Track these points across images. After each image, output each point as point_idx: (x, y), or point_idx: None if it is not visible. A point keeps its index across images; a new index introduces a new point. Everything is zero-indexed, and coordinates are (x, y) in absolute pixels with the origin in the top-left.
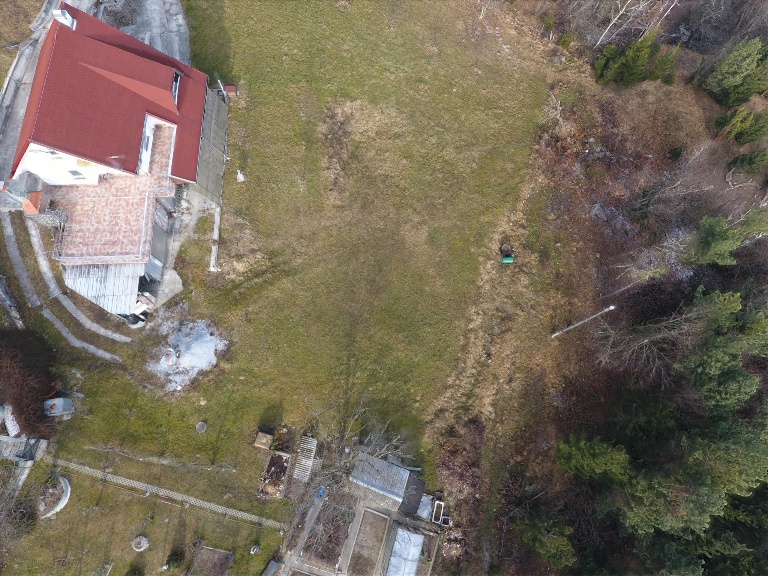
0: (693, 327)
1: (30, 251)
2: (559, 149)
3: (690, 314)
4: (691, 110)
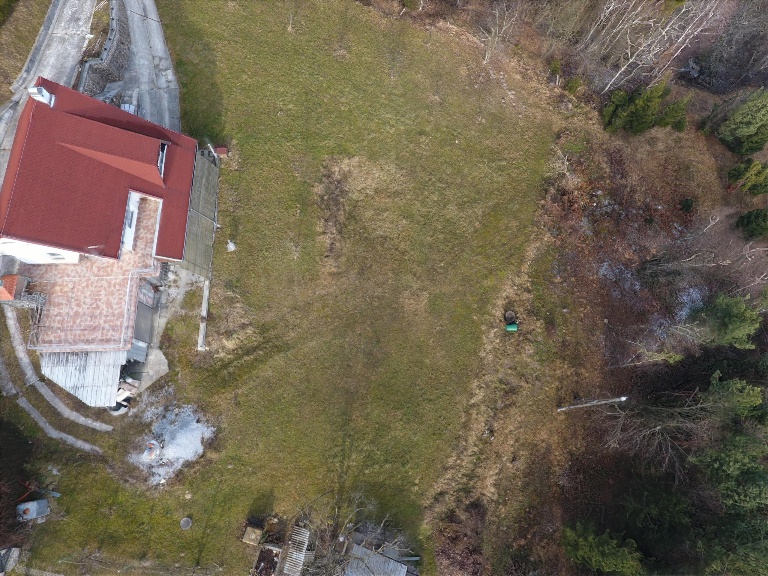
0: (709, 416)
1: (6, 335)
2: (566, 204)
3: (706, 404)
4: (702, 158)
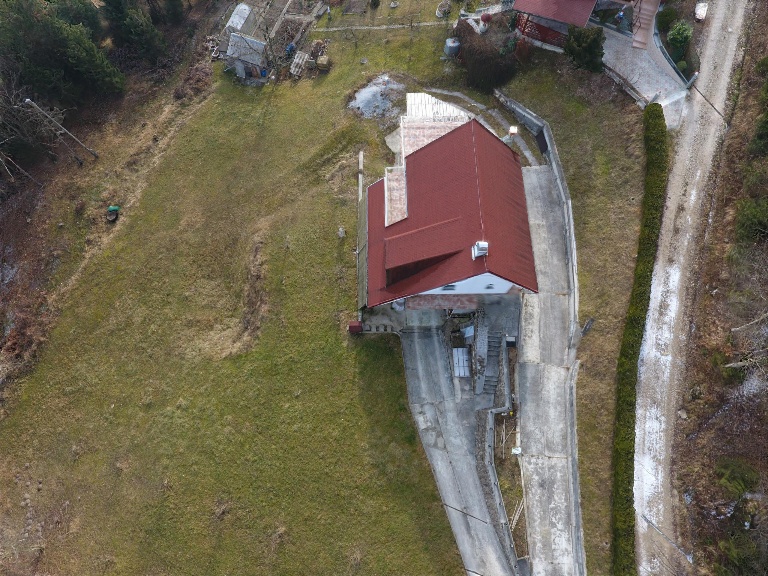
0: None
1: None
2: None
3: None
4: None
